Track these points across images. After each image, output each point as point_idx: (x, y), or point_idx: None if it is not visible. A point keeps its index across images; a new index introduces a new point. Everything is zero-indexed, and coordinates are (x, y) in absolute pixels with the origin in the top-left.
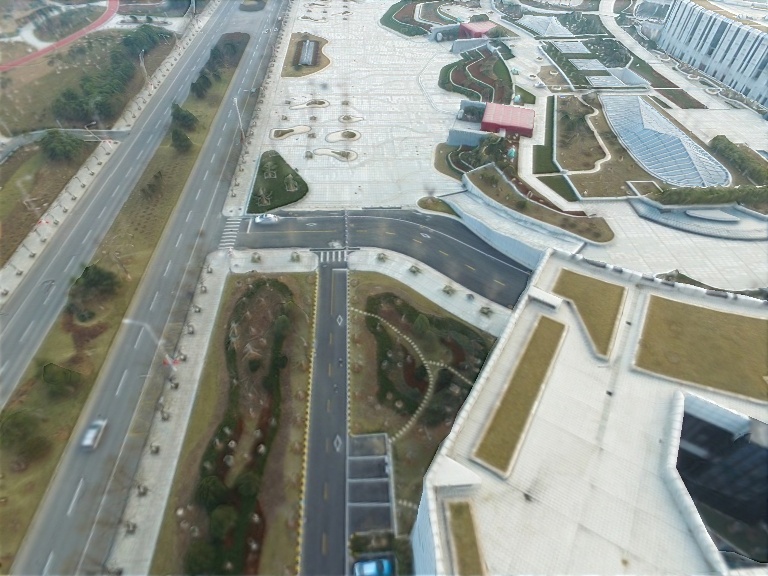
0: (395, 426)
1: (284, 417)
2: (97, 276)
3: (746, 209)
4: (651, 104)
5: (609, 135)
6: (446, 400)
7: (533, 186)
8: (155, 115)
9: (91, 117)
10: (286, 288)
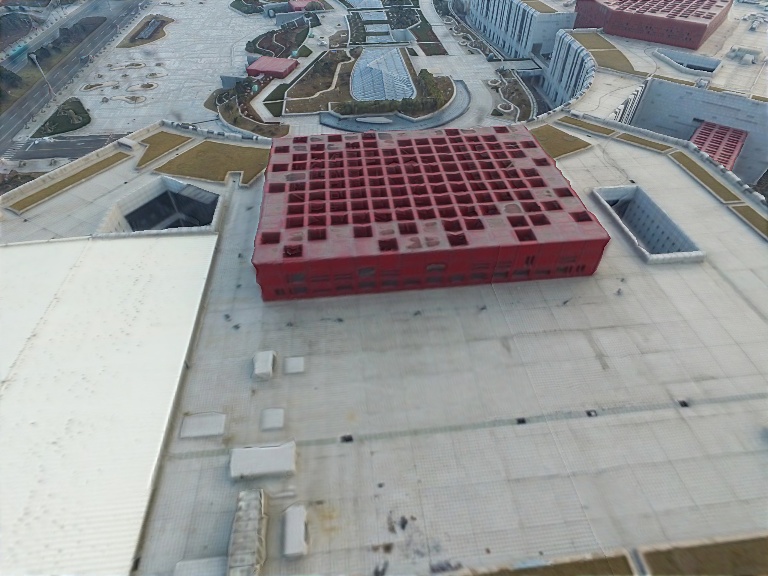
0: None
1: None
2: None
3: (403, 115)
4: (402, 53)
5: (345, 75)
6: None
7: (256, 109)
8: None
9: None
10: None
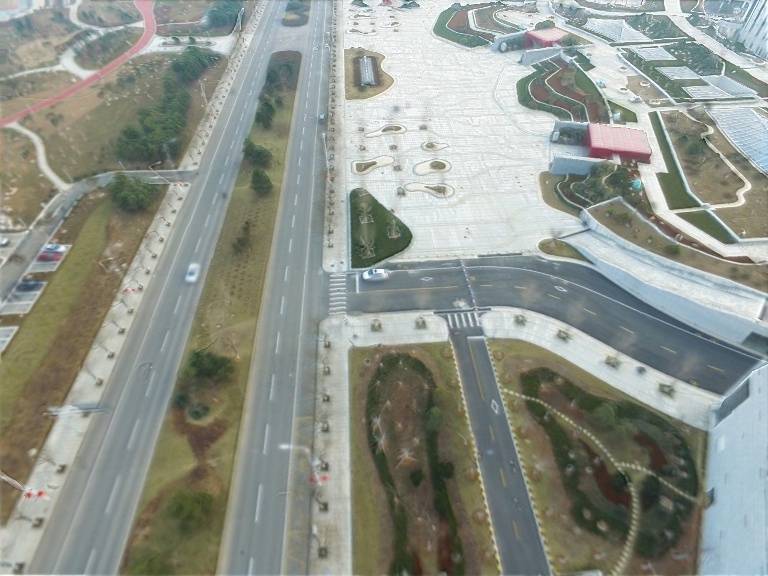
0: (607, 559)
1: (467, 549)
2: (211, 364)
3: None
4: None
5: (738, 158)
6: (663, 521)
7: (676, 225)
8: (221, 150)
9: (156, 157)
10: (422, 365)
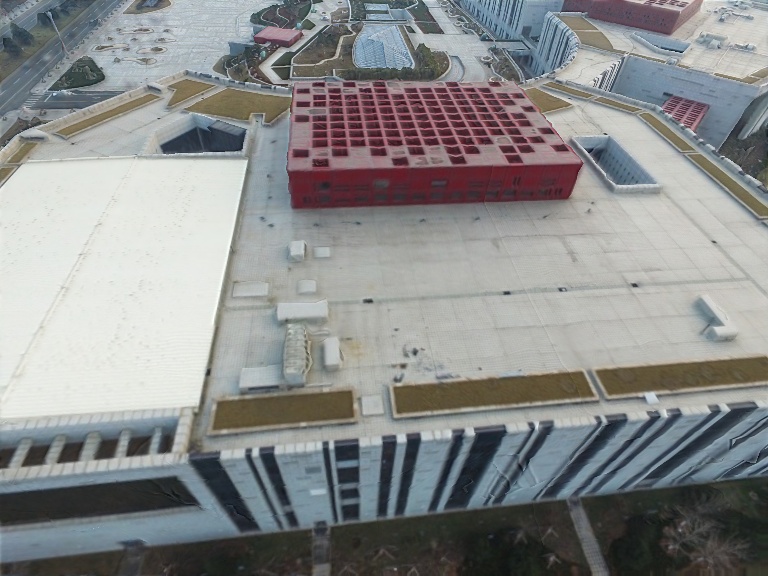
0: None
1: None
2: None
3: None
4: (401, 30)
5: (348, 46)
6: None
7: (264, 72)
8: (3, 36)
9: None
10: None
